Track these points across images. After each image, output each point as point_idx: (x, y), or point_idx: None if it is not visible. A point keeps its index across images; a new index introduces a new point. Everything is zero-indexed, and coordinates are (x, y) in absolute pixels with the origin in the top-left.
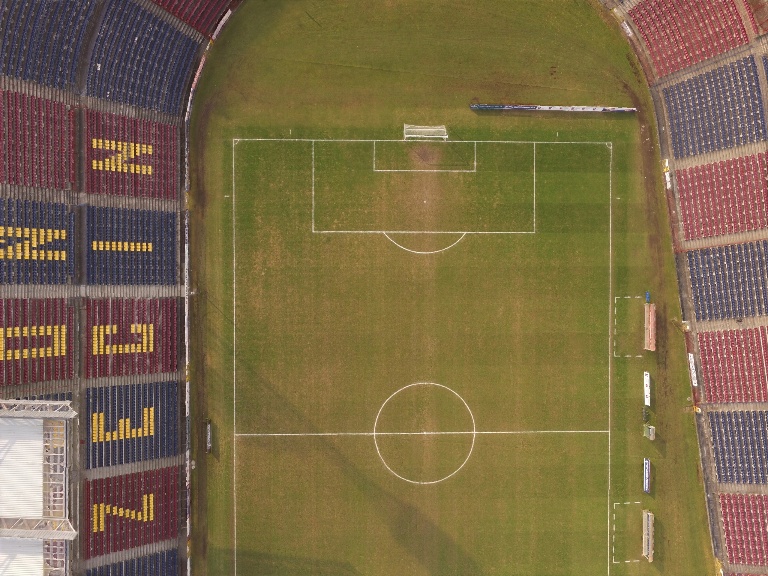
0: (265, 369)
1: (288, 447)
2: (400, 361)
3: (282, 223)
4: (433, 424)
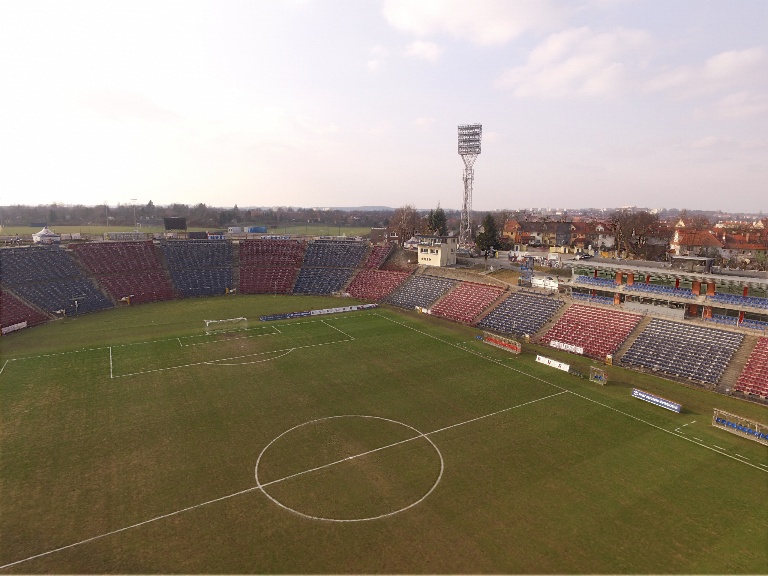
0: (2, 485)
1: (40, 575)
2: (266, 416)
3: (66, 381)
4: (356, 446)
